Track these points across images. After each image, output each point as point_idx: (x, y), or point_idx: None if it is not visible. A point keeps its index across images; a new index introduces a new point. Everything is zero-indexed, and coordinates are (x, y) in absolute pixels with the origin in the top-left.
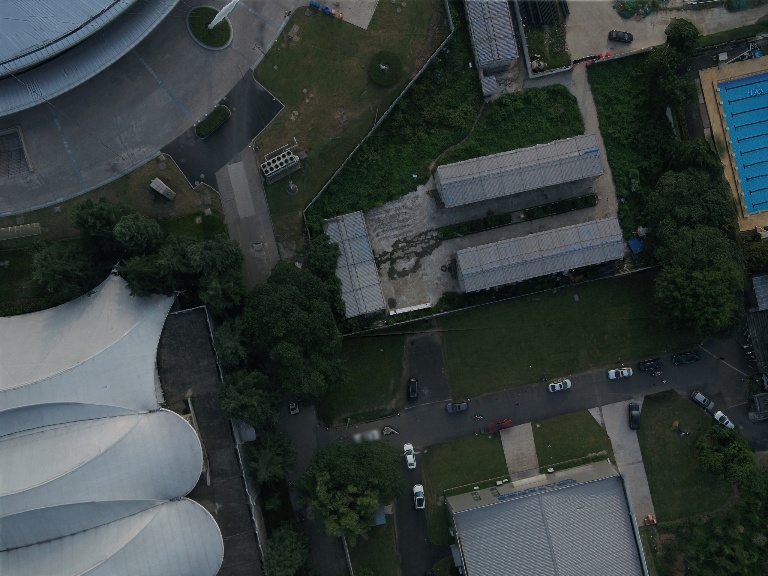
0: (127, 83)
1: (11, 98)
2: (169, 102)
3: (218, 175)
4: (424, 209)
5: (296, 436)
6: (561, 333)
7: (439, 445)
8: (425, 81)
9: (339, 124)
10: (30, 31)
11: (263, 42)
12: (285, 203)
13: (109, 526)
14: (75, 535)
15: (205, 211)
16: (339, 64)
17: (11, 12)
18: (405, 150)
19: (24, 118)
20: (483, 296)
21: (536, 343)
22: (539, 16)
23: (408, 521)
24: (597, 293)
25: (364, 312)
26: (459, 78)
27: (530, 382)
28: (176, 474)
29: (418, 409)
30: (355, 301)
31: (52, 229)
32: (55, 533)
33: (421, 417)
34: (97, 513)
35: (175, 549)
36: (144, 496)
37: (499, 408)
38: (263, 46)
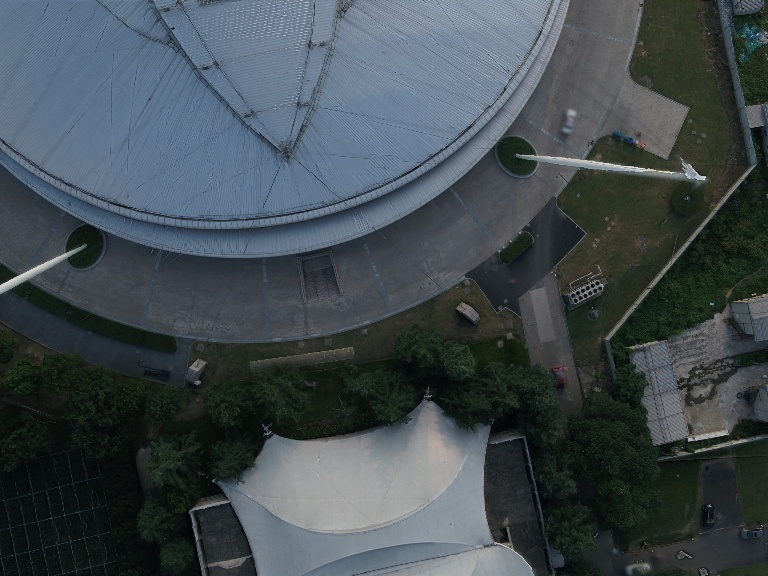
0: (435, 209)
1: (338, 229)
2: (475, 228)
3: (521, 300)
4: (720, 337)
5: (595, 560)
6: None
7: (732, 570)
8: (725, 212)
9: (639, 252)
10: (369, 168)
11: (566, 170)
12: (585, 329)
13: None
14: None
15: (507, 335)
16: (641, 193)
17: (356, 151)
18: (703, 279)
19: None
20: None
21: None
22: None
23: None
24: None
25: (669, 441)
26: (756, 208)
27: None
28: None
29: (712, 534)
30: (660, 430)
31: (358, 351)
32: None
33: (715, 542)
34: None
35: None
36: None
37: None
38: (566, 174)
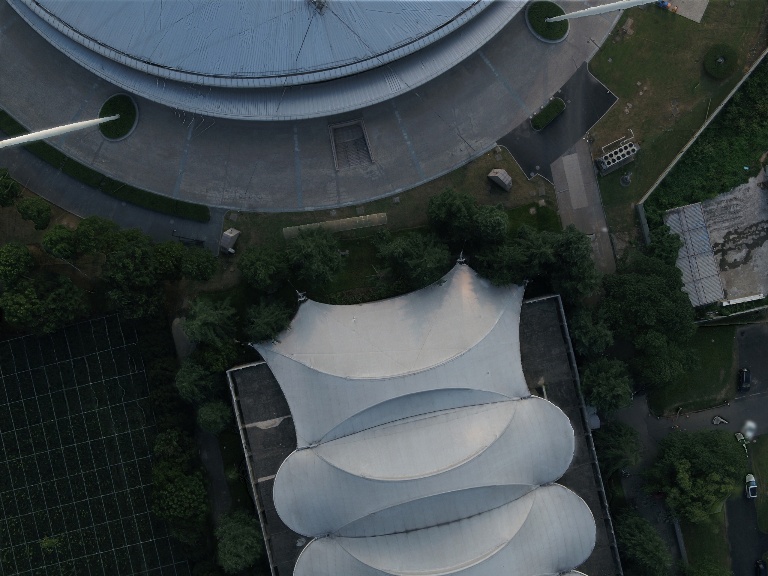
0: (466, 76)
1: (370, 90)
2: (506, 94)
3: (553, 167)
4: (755, 201)
5: (630, 425)
6: None
7: None
8: (759, 74)
9: (672, 116)
10: (401, 24)
11: (598, 35)
12: (618, 194)
13: (500, 509)
14: (472, 518)
15: (539, 202)
16: (673, 57)
17: (388, 5)
18: (737, 142)
19: (368, 110)
20: None
21: None
22: None
23: (738, 510)
24: None
25: (705, 302)
26: None
27: None
28: (551, 460)
29: (747, 399)
30: (695, 292)
31: (391, 219)
32: (454, 515)
33: (750, 407)
34: (492, 497)
35: (554, 533)
36: (526, 481)
37: None
38: (597, 39)
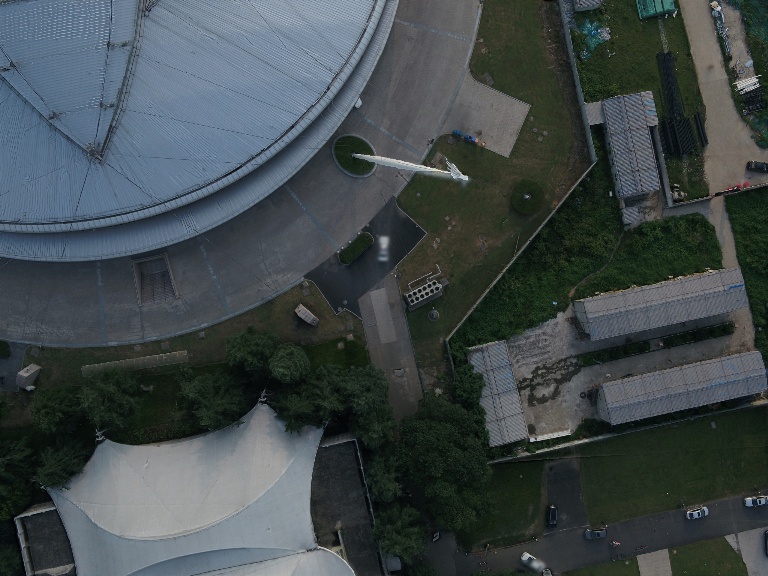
0: (272, 210)
1: (165, 231)
2: (313, 229)
3: (361, 301)
4: (564, 336)
5: (437, 562)
6: (698, 460)
7: (577, 571)
8: (566, 210)
9: (480, 251)
10: (190, 169)
11: (406, 170)
12: (426, 329)
13: None
14: None
15: (347, 337)
16: (481, 192)
17: (174, 152)
18: (545, 278)
19: (172, 245)
20: (624, 425)
21: (673, 470)
22: (679, 146)
23: None
24: (734, 420)
25: (508, 442)
26: (599, 206)
27: (667, 508)
28: None
29: (556, 535)
30: (499, 430)
31: (196, 354)
32: None
33: (559, 543)
34: None
35: None
36: None
37: (636, 534)
38: (406, 173)
